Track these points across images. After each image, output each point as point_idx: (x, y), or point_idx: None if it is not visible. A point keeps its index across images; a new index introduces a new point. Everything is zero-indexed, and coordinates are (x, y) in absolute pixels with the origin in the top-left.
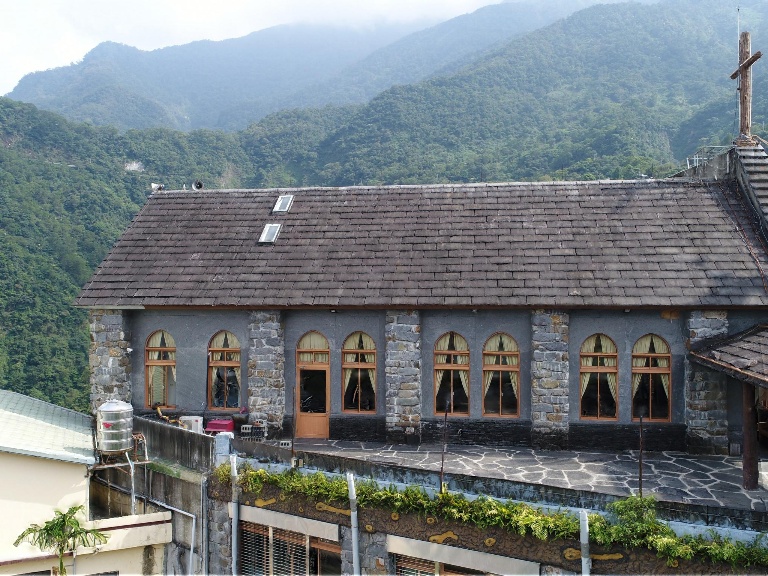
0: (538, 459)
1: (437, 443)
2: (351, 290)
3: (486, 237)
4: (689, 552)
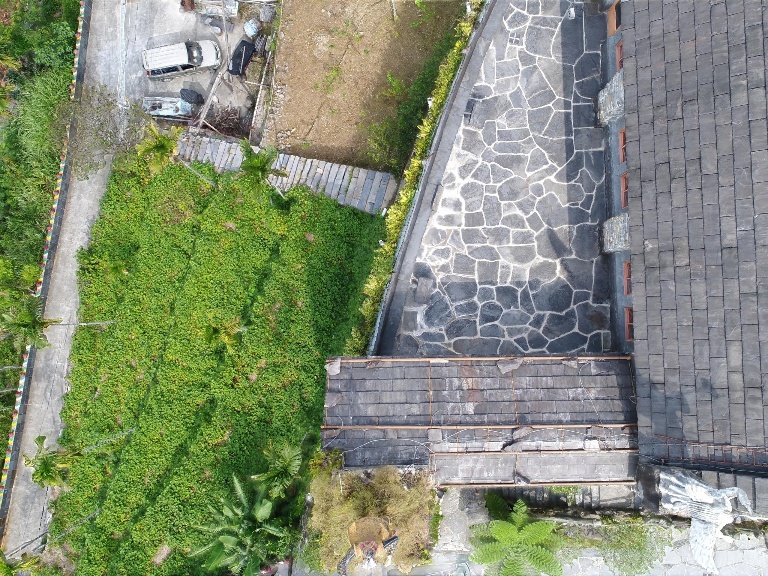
0: (566, 227)
1: (604, 141)
2: (646, 5)
3: (763, 133)
4: (370, 294)
